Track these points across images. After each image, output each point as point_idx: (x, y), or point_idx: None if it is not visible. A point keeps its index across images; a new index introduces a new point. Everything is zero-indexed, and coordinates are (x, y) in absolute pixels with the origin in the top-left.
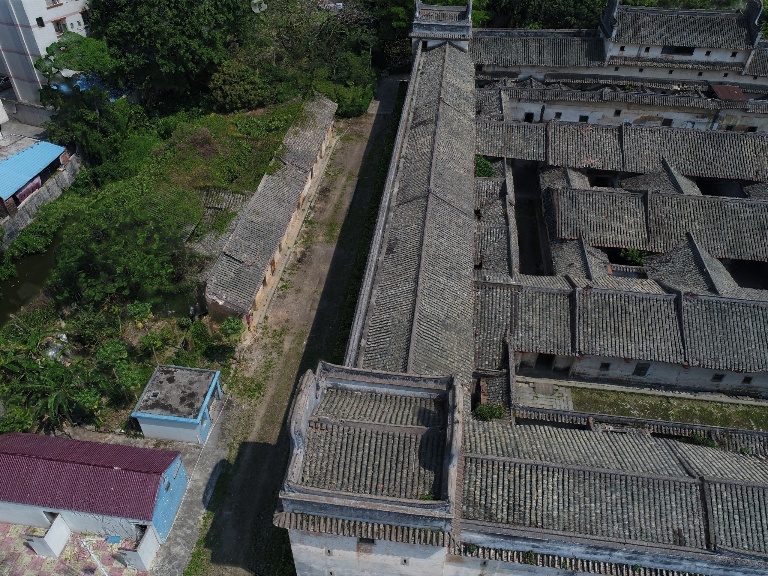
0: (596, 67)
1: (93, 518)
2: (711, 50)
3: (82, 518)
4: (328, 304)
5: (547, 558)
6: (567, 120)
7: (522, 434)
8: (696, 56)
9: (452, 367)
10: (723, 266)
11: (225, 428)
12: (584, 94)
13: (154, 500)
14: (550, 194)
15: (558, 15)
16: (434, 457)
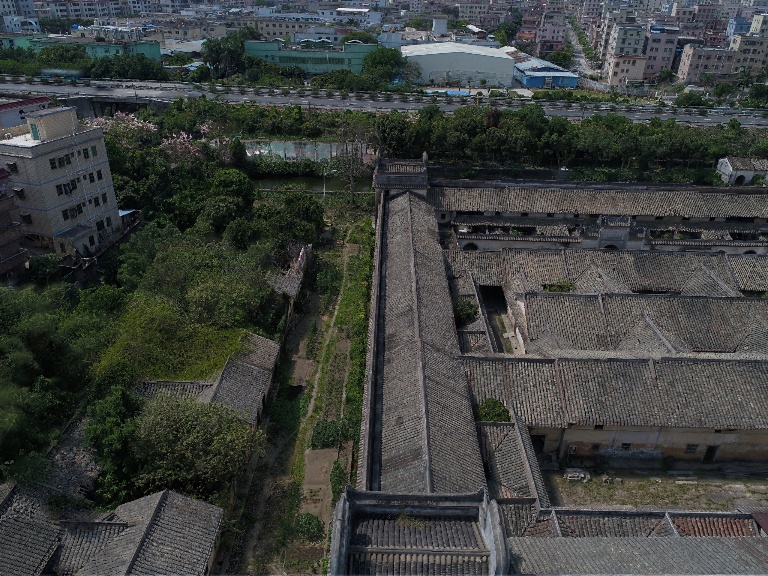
0: None
1: None
2: None
3: None
4: None
5: None
6: None
7: (761, 211)
8: None
9: None
10: None
11: None
12: None
13: None
14: None
15: None
16: None
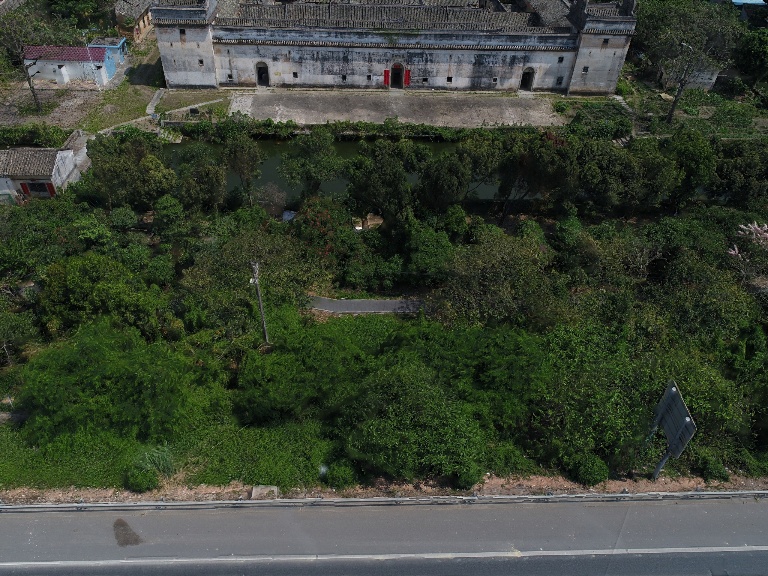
0: None
1: (79, 65)
2: None
3: (75, 67)
4: None
5: (246, 41)
6: None
7: None
8: None
9: (222, 13)
10: None
11: (131, 61)
12: None
13: (104, 55)
14: None
15: None
16: None
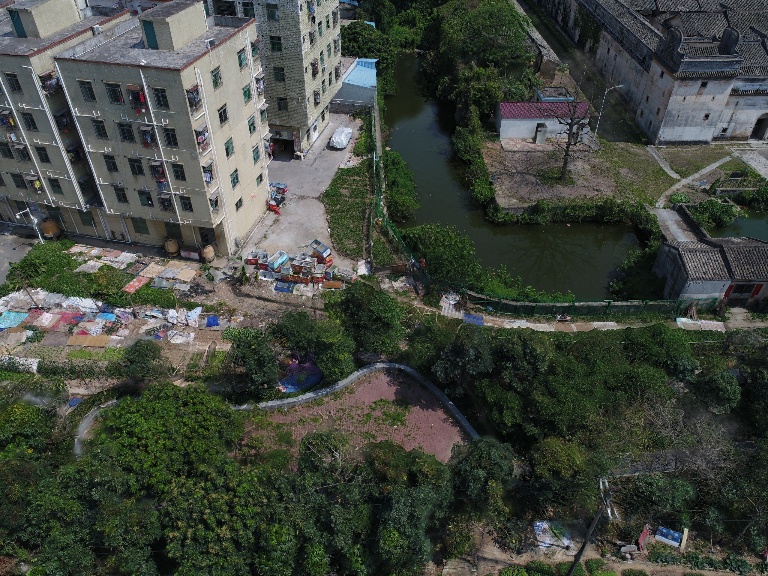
0: None
1: None
2: None
3: (555, 124)
4: (577, 77)
5: (764, 92)
6: None
7: None
8: None
9: None
10: None
11: None
12: None
13: None
14: (668, 23)
15: None
16: (724, 52)
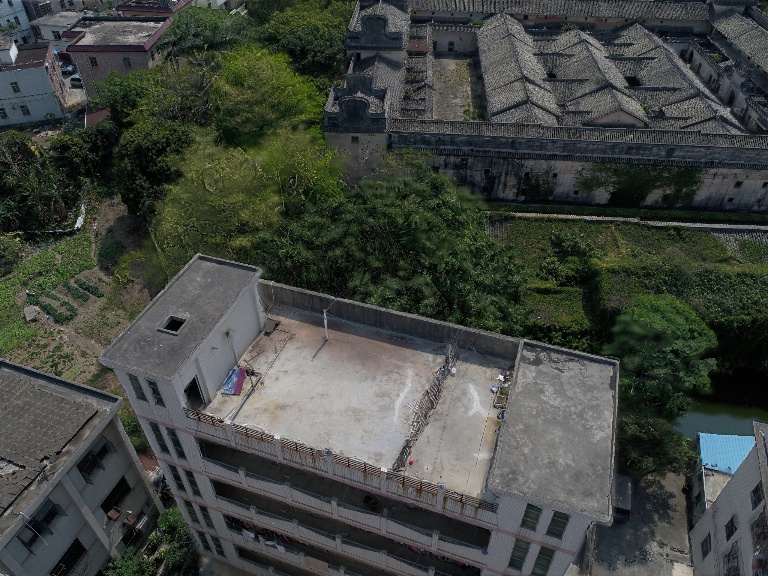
0: None
1: None
2: None
3: None
4: None
5: None
6: None
7: None
8: None
9: None
10: None
11: None
12: (428, 93)
13: None
14: (592, 124)
15: (327, 60)
16: None
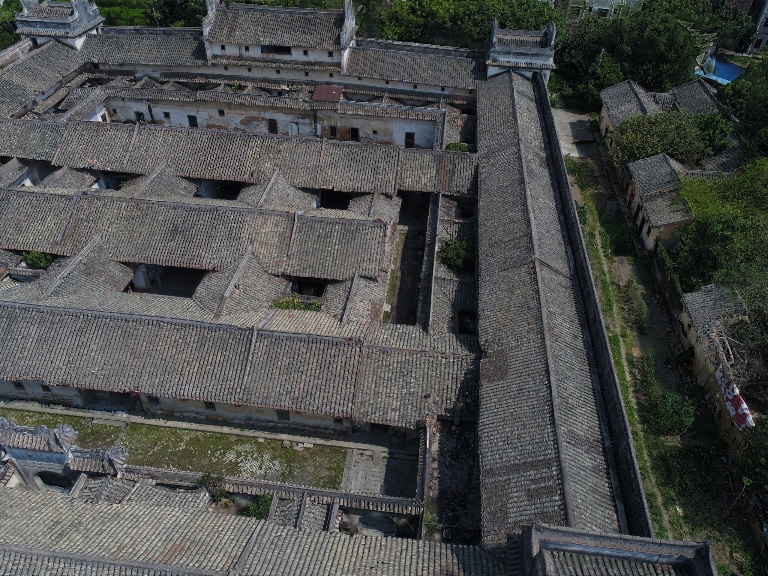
0: (205, 66)
1: None
2: (307, 50)
3: None
4: None
5: None
6: (177, 120)
7: None
8: (295, 56)
9: None
10: (126, 270)
11: None
12: (181, 93)
13: None
14: None
15: (193, 13)
16: None
